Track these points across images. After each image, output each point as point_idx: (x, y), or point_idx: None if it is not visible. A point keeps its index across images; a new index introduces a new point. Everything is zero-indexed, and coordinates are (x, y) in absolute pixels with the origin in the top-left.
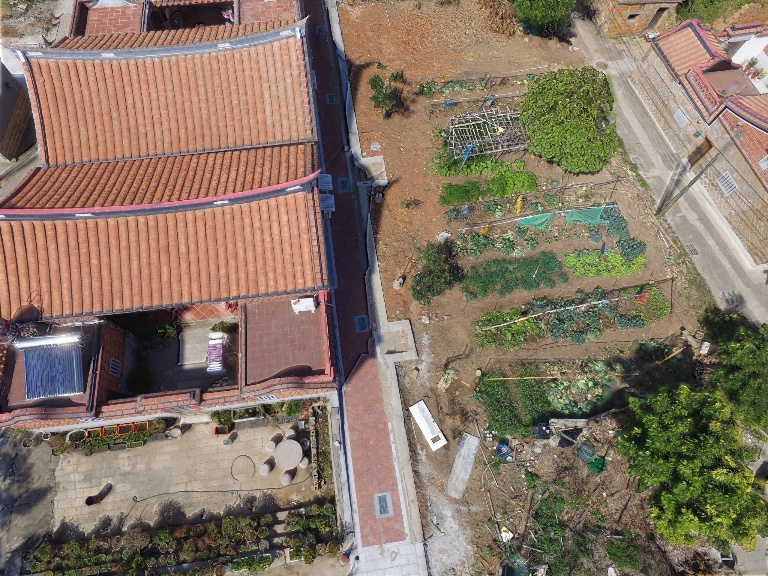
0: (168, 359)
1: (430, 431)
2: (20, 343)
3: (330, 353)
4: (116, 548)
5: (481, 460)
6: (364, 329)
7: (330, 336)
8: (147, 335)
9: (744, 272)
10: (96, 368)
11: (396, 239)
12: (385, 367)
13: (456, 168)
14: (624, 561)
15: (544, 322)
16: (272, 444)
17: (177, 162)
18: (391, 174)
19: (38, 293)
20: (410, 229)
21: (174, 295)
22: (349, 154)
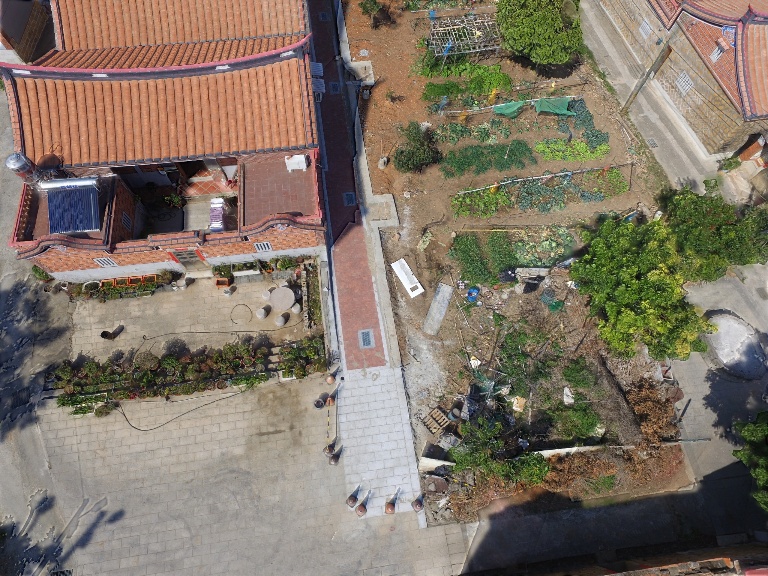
0: (174, 227)
1: (409, 282)
2: (44, 184)
3: (319, 203)
4: (128, 371)
5: (454, 304)
6: (351, 203)
7: (319, 191)
8: (155, 203)
9: (698, 161)
10: (111, 212)
11: (382, 128)
12: (370, 232)
13: (438, 70)
14: (578, 380)
15: (514, 196)
16: (267, 292)
17: (182, 47)
18: (378, 76)
19: (59, 144)
20: (394, 120)
21: (180, 149)
22: (340, 62)
